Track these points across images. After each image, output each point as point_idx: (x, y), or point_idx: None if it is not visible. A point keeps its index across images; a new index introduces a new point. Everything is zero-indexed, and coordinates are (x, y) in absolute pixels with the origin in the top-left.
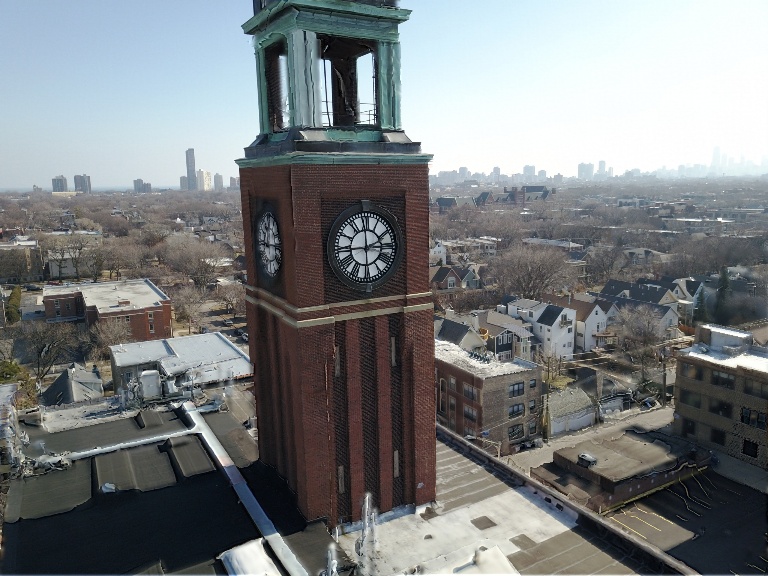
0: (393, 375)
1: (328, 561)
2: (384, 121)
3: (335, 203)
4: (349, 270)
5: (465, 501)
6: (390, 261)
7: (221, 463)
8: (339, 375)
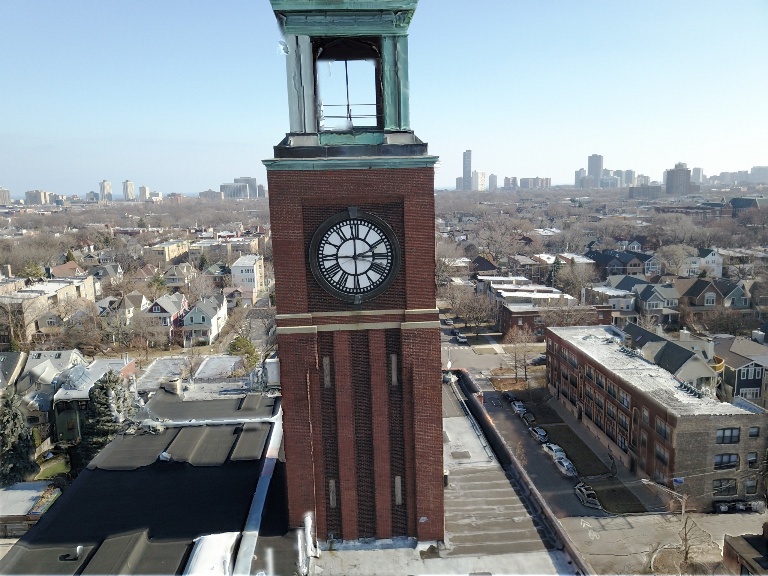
0: (393, 395)
1: (224, 570)
2: (387, 121)
3: (320, 210)
4: (335, 279)
5: (481, 550)
6: (385, 272)
7: (266, 454)
8: (329, 386)
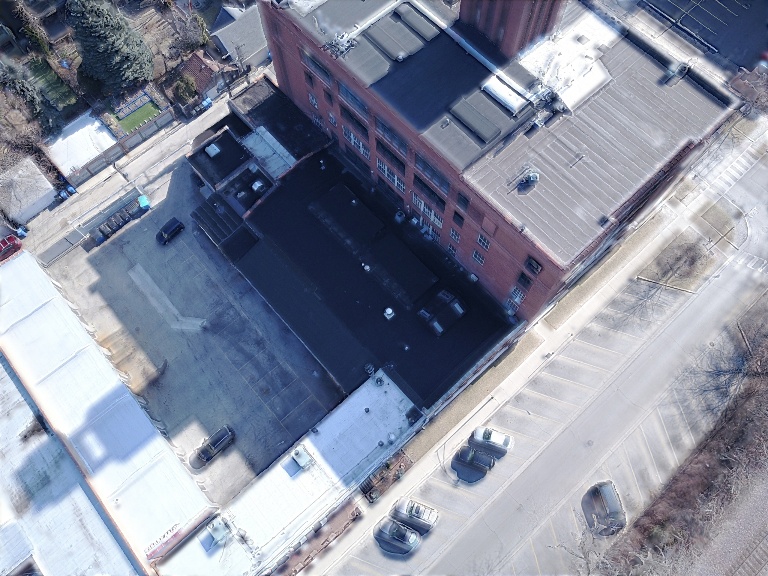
0: None
1: None
2: None
3: None
4: None
5: (571, 26)
6: None
7: (441, 27)
8: None
